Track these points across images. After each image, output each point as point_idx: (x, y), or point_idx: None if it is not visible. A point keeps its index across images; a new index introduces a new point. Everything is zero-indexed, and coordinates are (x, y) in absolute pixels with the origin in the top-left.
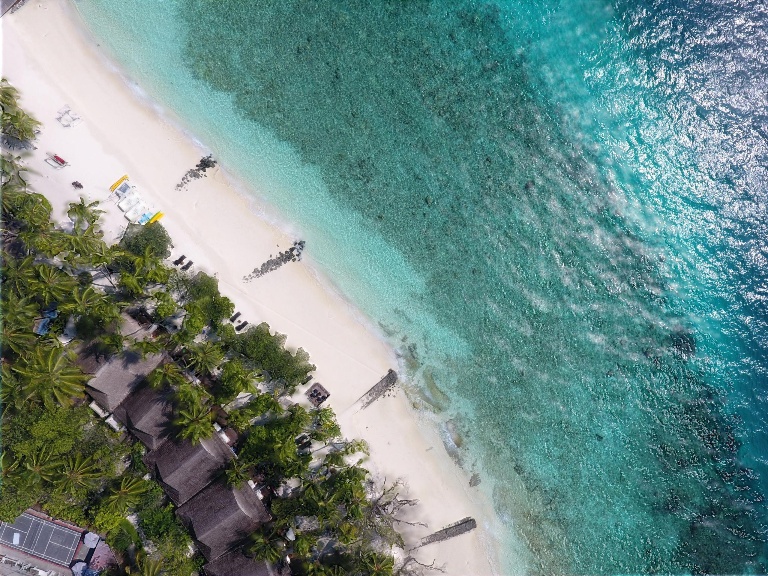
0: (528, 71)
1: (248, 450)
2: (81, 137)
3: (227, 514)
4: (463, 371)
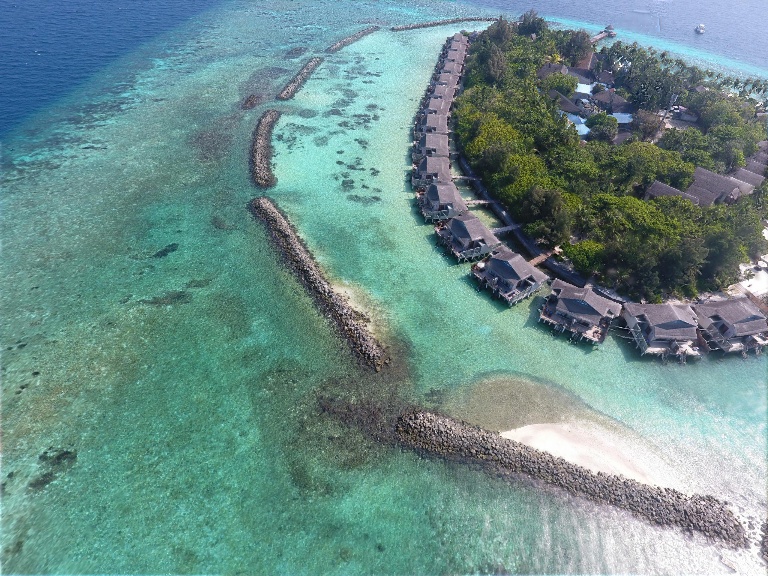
0: (722, 65)
1: None
2: None
3: None
4: (762, 98)
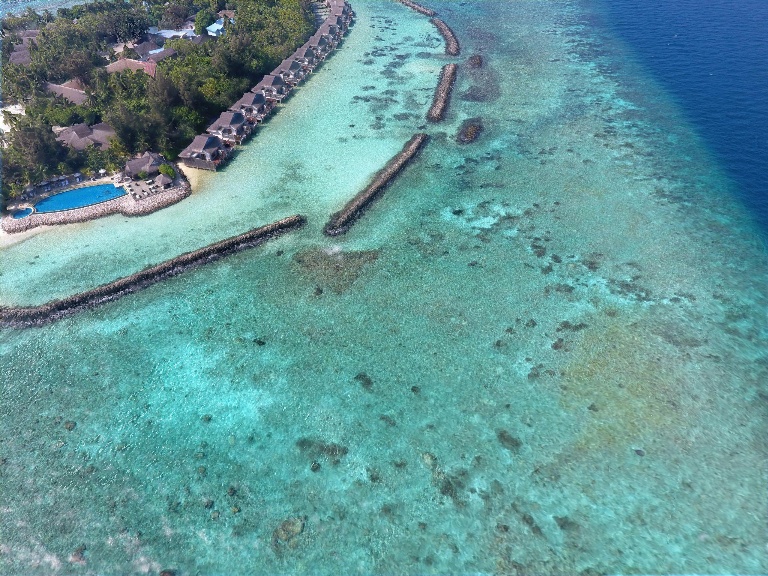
0: None
1: (2, 66)
2: (1, 127)
3: (15, 53)
4: None
